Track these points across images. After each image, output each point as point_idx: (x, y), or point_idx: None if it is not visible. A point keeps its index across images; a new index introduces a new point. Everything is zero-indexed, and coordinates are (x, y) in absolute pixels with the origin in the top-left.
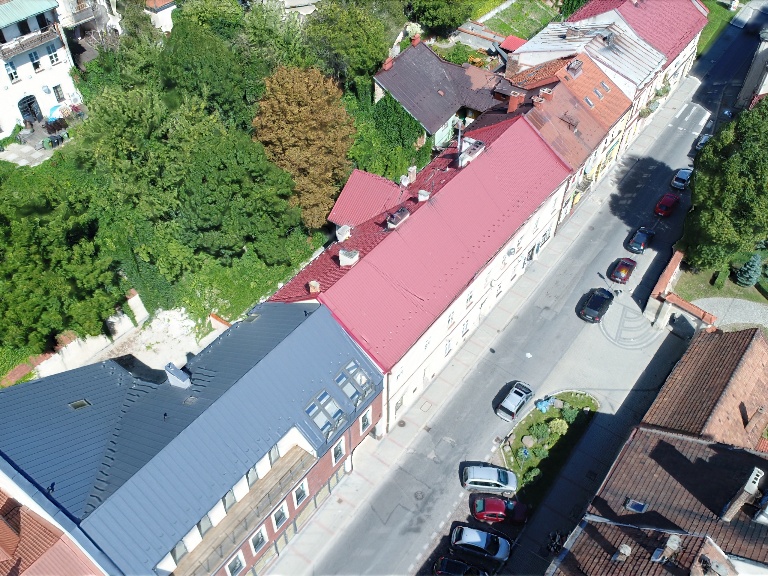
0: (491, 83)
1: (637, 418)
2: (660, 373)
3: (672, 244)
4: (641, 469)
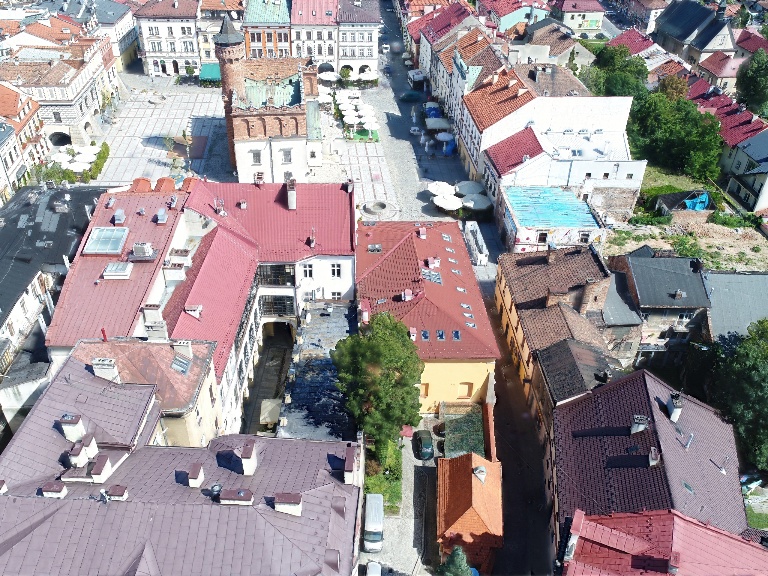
0: (656, 78)
1: None
2: None
3: None
4: None
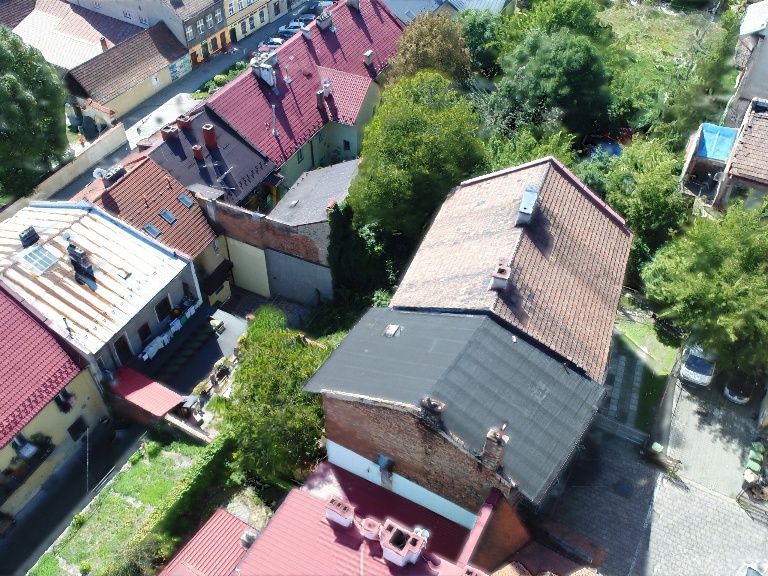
0: None
1: (167, 92)
2: (137, 115)
3: (66, 193)
4: (191, 2)
